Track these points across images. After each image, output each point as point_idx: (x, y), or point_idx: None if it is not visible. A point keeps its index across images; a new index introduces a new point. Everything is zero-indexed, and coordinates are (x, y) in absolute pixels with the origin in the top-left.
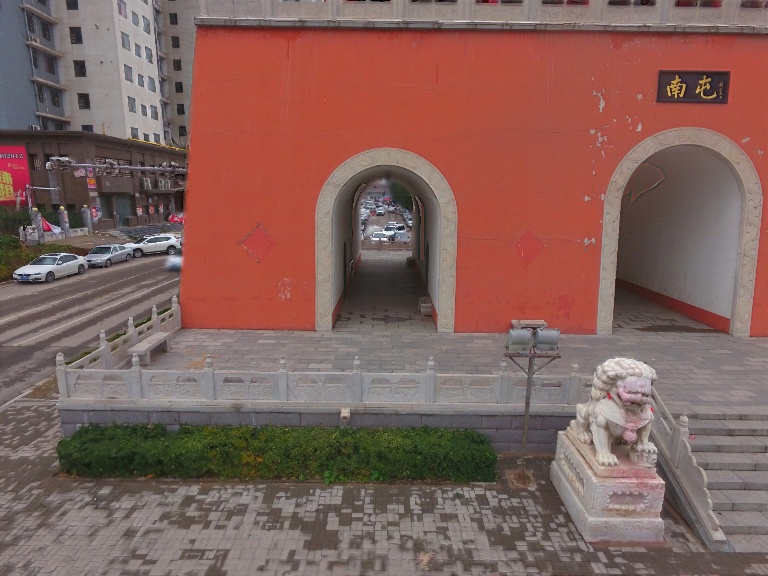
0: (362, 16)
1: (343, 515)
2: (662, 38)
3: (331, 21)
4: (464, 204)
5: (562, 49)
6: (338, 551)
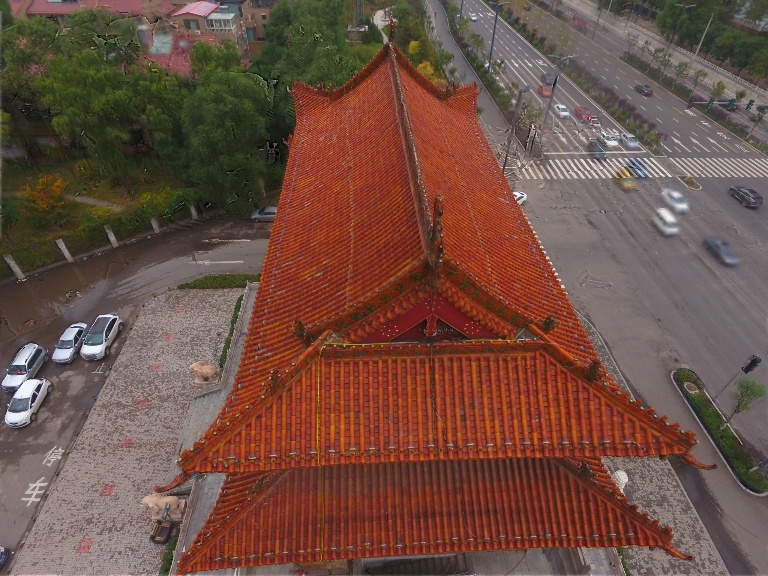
0: None
1: (640, 568)
2: None
3: None
4: None
5: None
6: (652, 567)
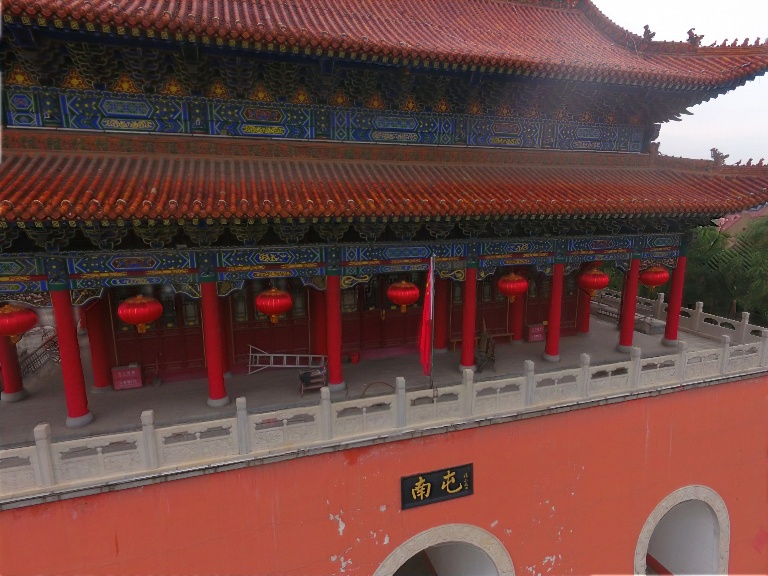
0: None
1: None
2: (400, 444)
3: None
4: None
5: (287, 478)
6: None
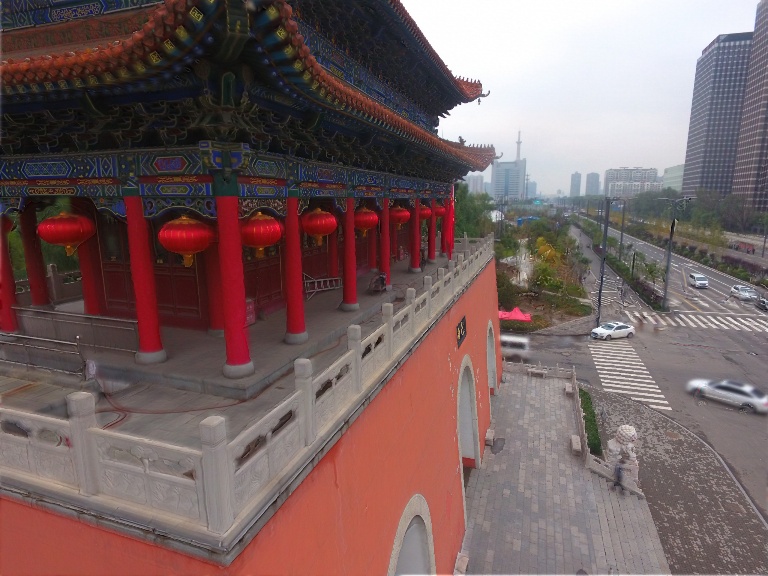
0: (372, 373)
1: None
2: None
3: (364, 401)
4: (431, 509)
5: None
6: None
